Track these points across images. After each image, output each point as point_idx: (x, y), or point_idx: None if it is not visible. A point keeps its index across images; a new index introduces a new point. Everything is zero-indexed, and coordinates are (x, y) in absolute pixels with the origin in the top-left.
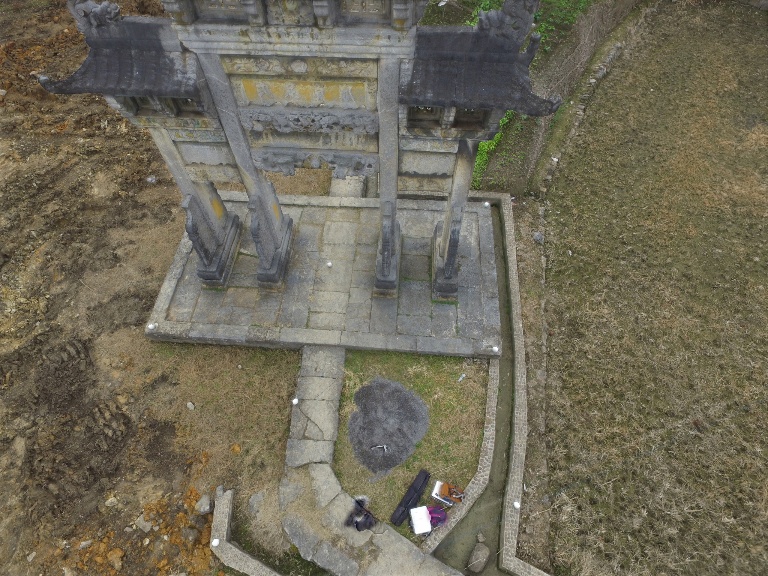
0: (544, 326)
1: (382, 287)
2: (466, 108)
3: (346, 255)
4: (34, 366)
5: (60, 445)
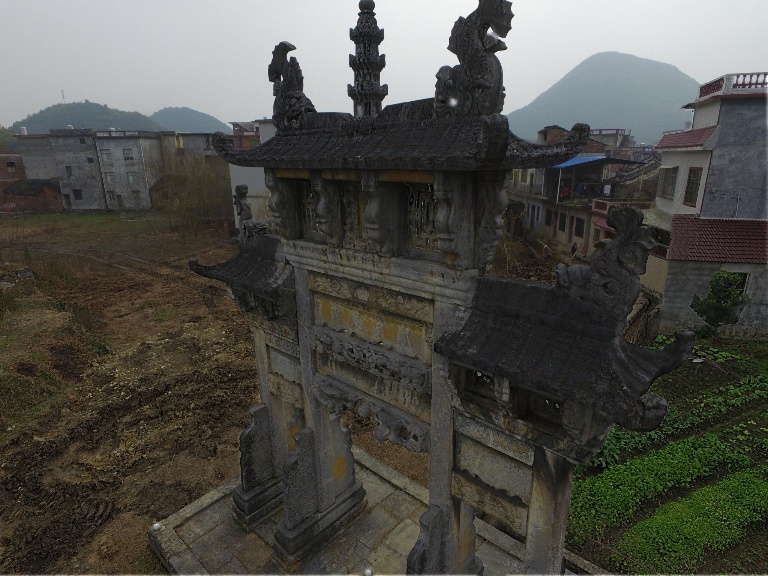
0: None
1: None
2: (526, 387)
3: (397, 574)
4: None
5: None
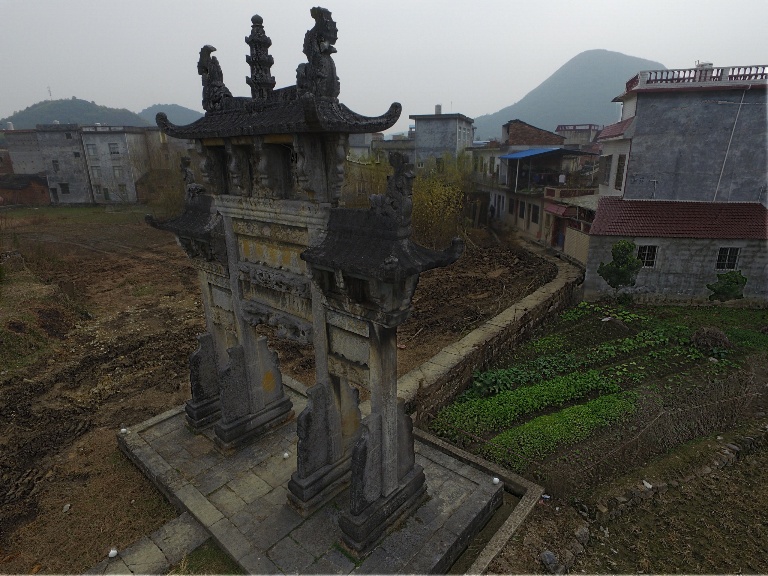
0: None
1: (294, 491)
2: (352, 276)
3: None
4: None
5: None
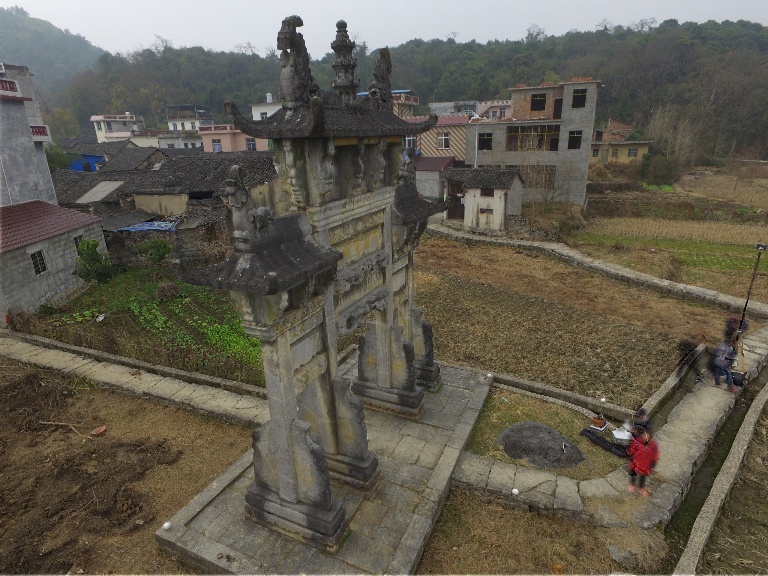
0: None
1: None
2: None
3: None
4: None
5: None
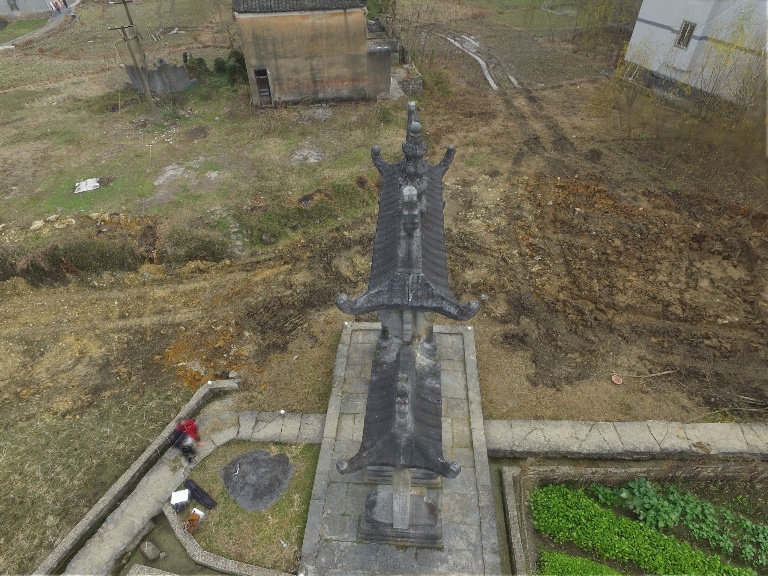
0: None
1: None
2: None
3: None
4: None
5: (284, 307)
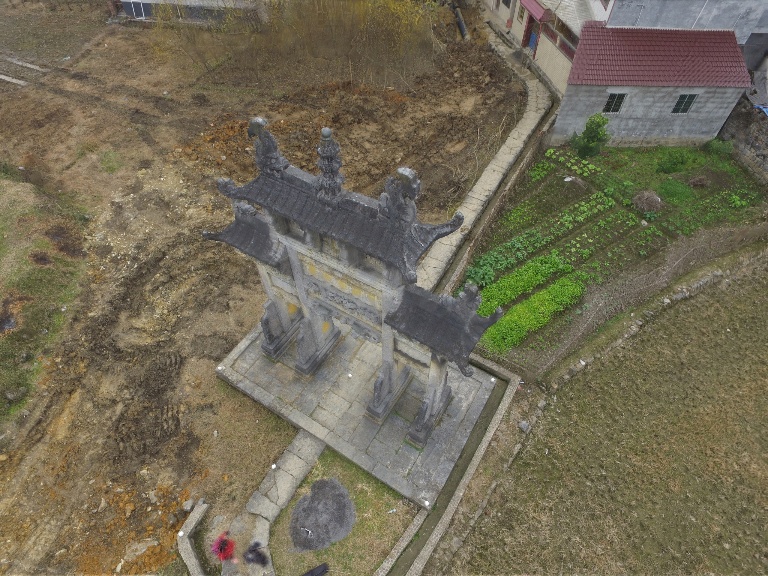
0: (482, 504)
1: (371, 413)
2: None
3: (366, 373)
4: (150, 359)
5: (138, 420)
